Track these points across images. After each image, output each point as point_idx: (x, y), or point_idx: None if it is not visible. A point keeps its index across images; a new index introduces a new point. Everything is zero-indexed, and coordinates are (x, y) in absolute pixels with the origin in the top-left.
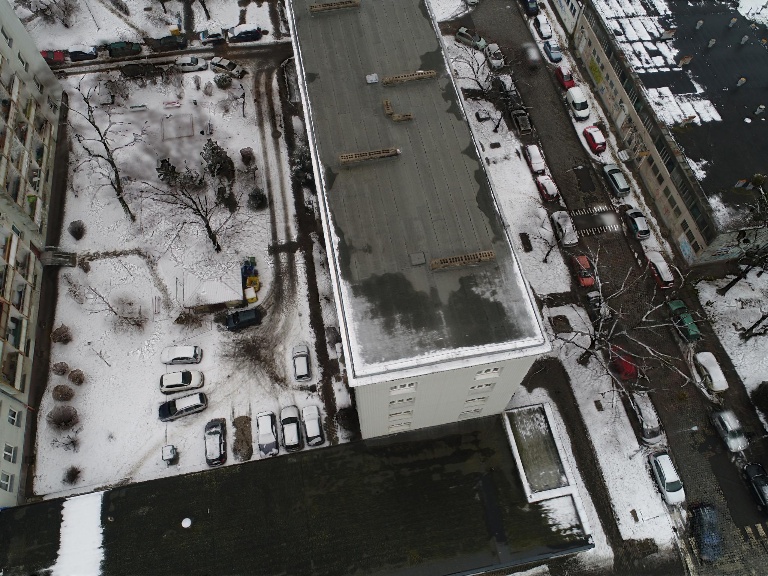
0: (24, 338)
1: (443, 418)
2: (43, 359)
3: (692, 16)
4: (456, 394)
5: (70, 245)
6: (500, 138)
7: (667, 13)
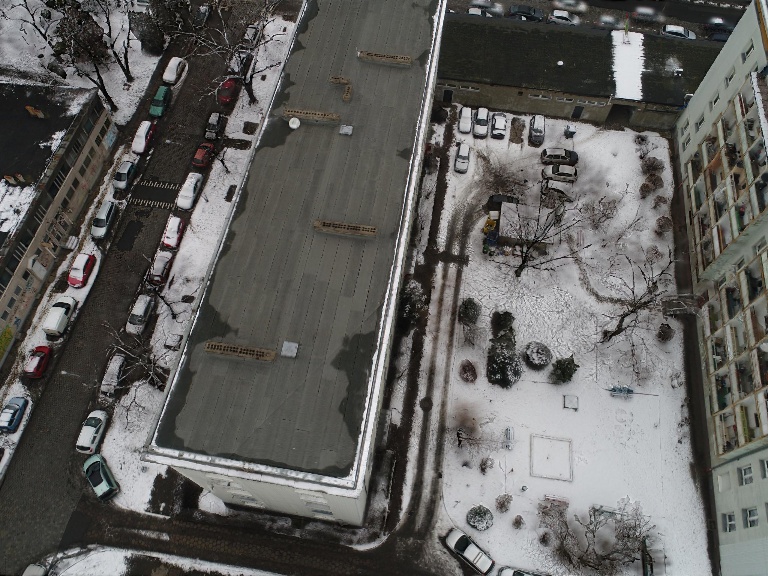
0: None
1: None
2: (678, 224)
3: None
4: None
5: (671, 326)
6: (176, 307)
7: None
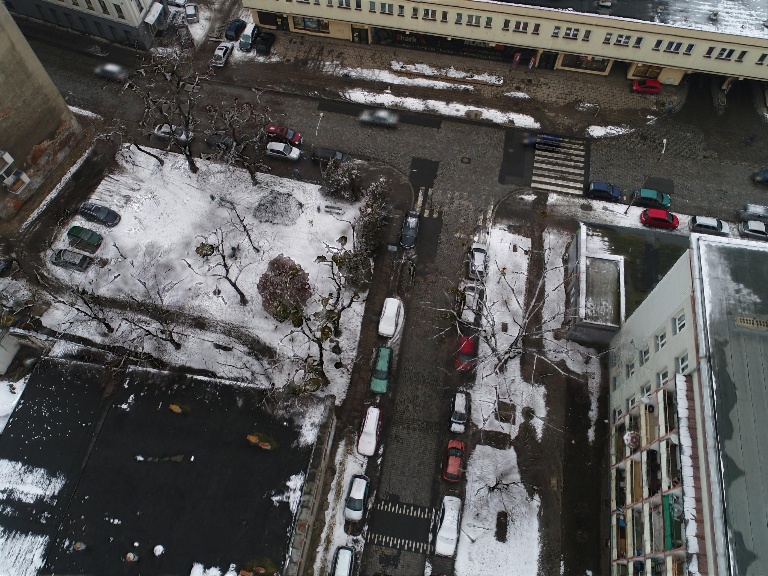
0: None
1: None
2: None
3: None
4: None
5: None
6: None
7: None
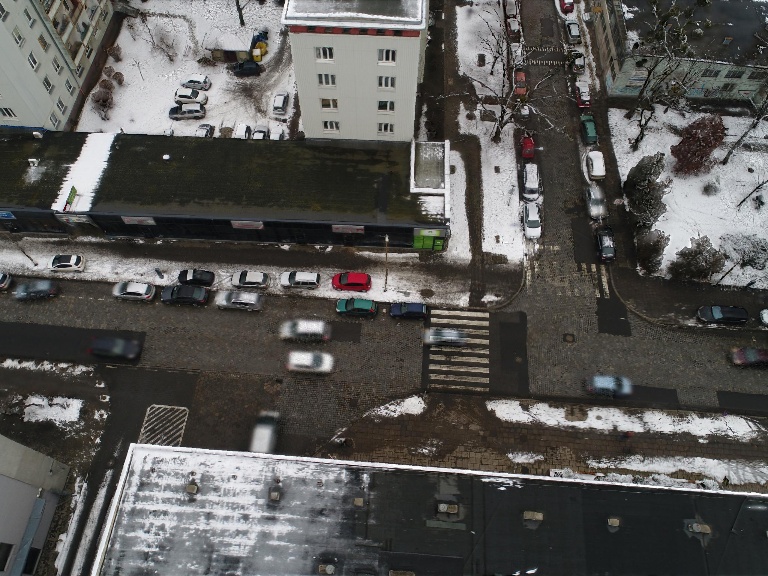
0: (88, 38)
1: (365, 128)
2: (99, 68)
3: None
4: (367, 85)
5: (137, 5)
6: None
7: None
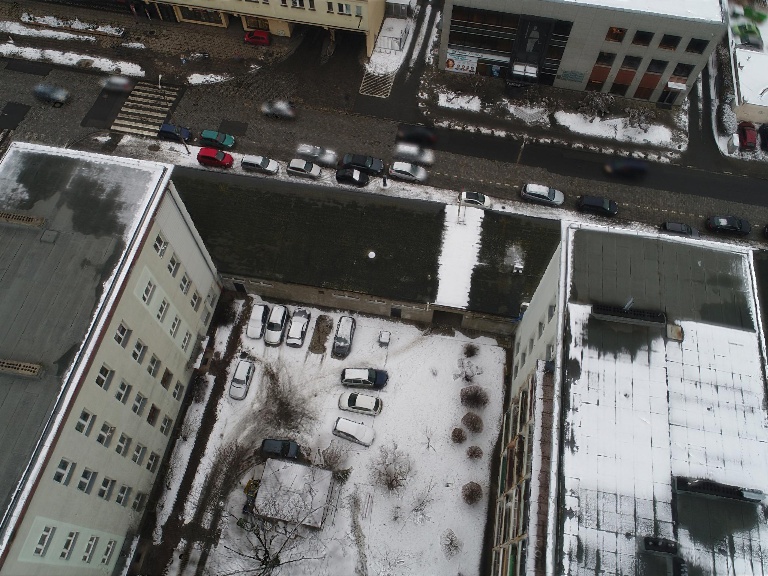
0: None
1: None
2: (497, 483)
3: None
4: None
5: None
6: None
7: None
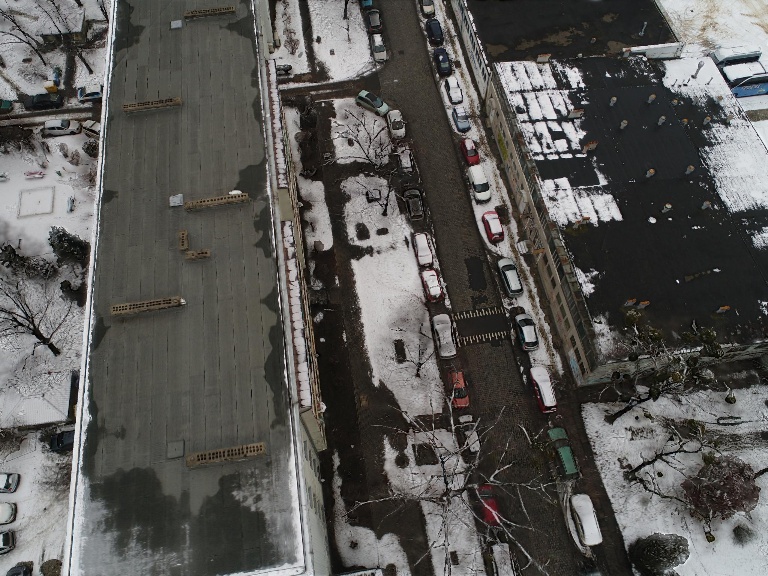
0: None
1: None
2: None
3: (608, 90)
4: None
5: None
6: (389, 223)
7: (580, 86)
